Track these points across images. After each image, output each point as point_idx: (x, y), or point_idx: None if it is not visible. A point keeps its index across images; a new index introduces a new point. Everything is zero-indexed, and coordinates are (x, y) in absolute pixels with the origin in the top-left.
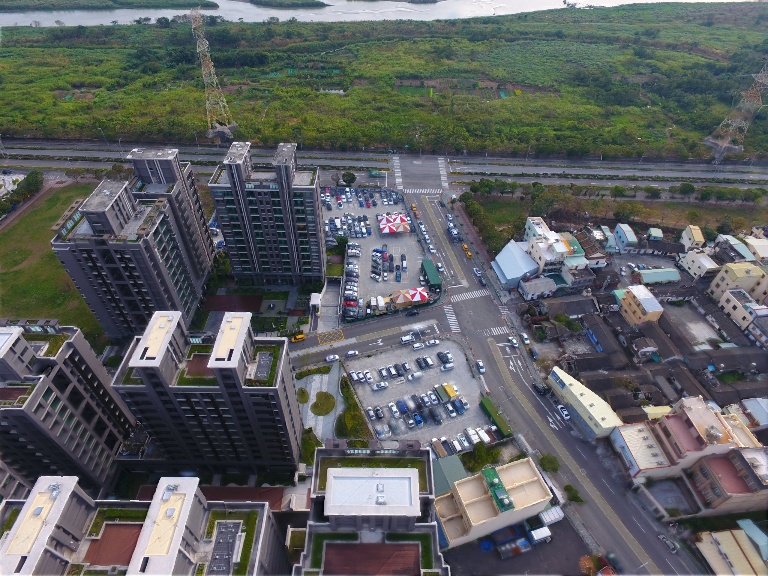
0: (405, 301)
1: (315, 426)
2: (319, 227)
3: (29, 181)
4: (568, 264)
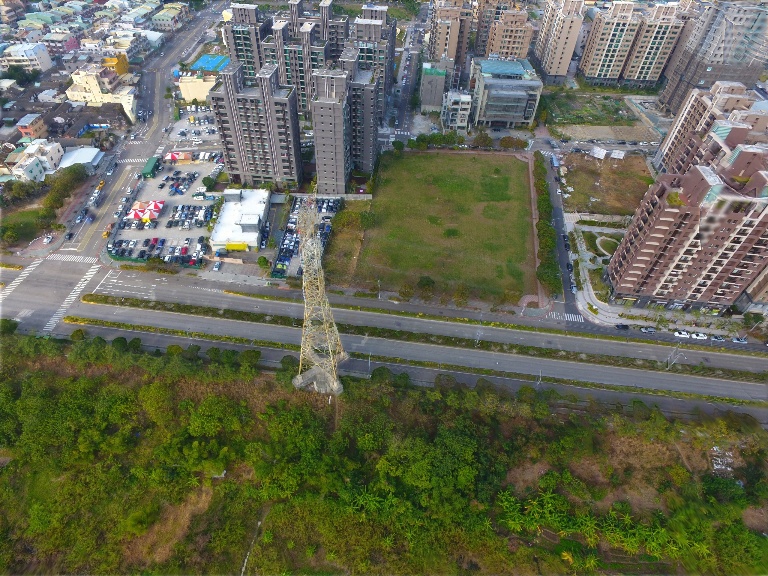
0: (185, 152)
1: None
2: None
3: (546, 266)
4: None
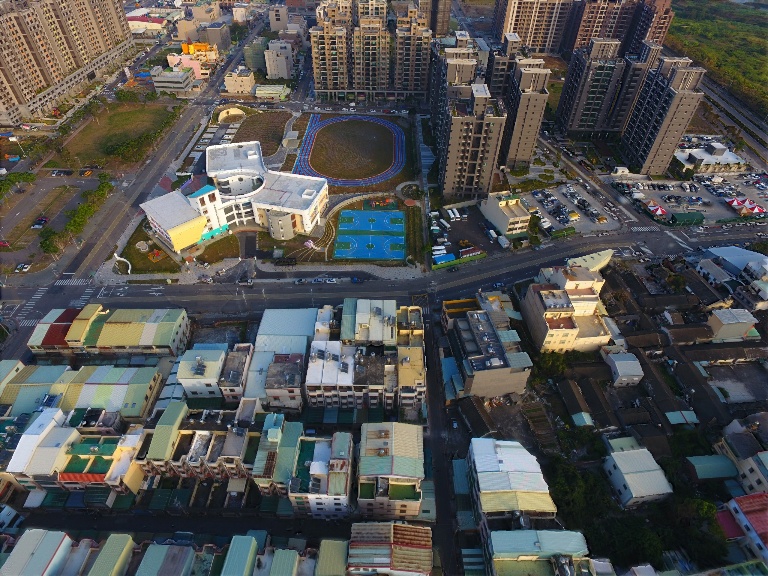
0: (645, 203)
1: (532, 175)
2: (666, 129)
3: None
4: (756, 281)
